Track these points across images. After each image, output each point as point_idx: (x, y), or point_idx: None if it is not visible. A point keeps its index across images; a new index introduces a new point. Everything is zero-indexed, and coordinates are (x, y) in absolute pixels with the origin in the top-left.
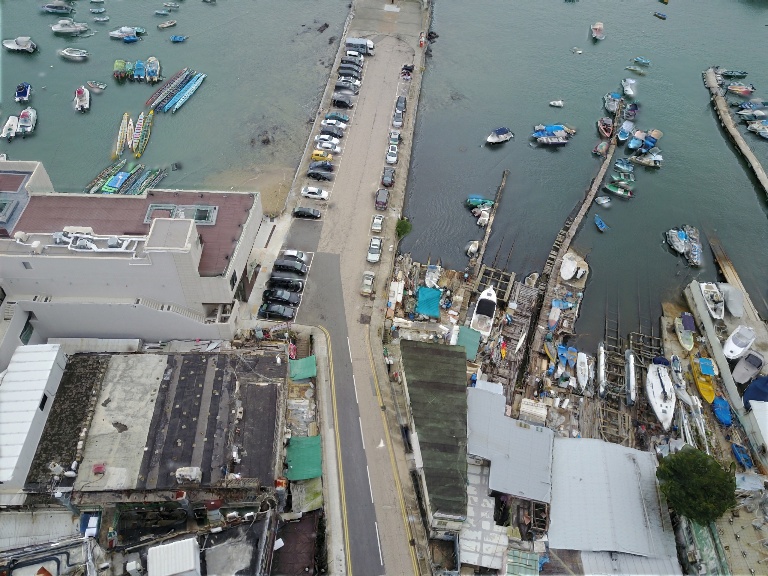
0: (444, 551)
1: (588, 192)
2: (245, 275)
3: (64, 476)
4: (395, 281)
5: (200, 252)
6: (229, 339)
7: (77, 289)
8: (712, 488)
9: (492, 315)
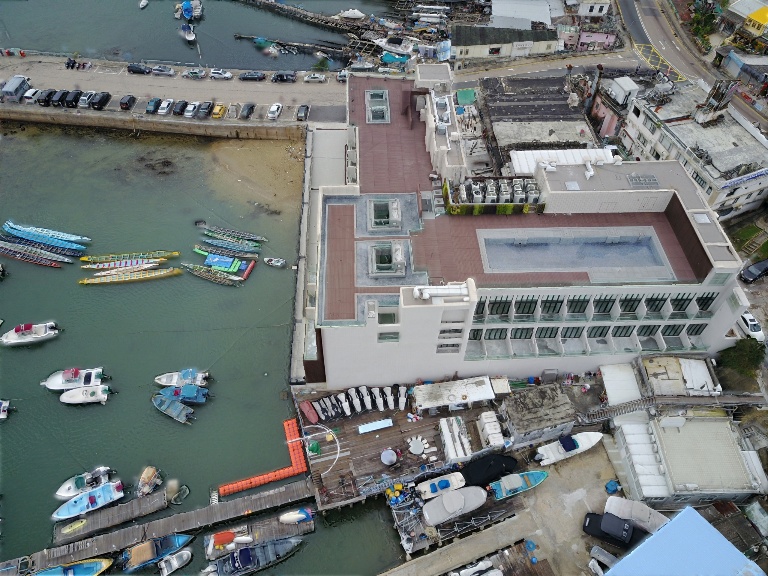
0: None
1: (264, 6)
2: None
3: None
4: None
5: None
6: None
7: None
8: None
9: None
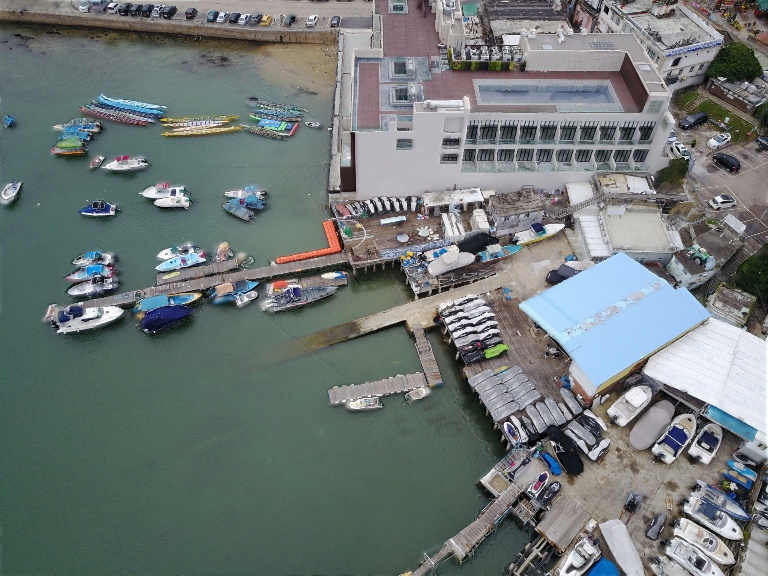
0: None
1: None
2: None
3: None
4: None
5: None
6: None
7: None
8: None
9: None
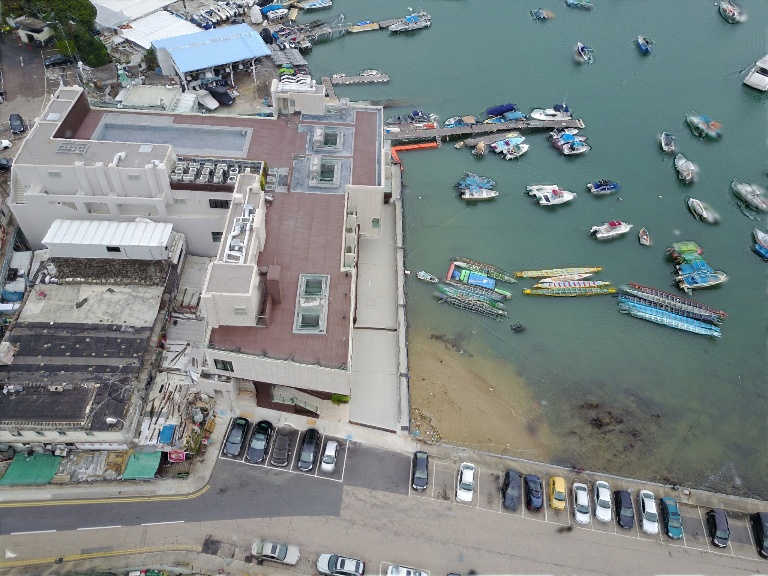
0: None
1: None
2: (262, 387)
3: None
4: None
5: (248, 323)
6: None
7: None
8: None
9: None
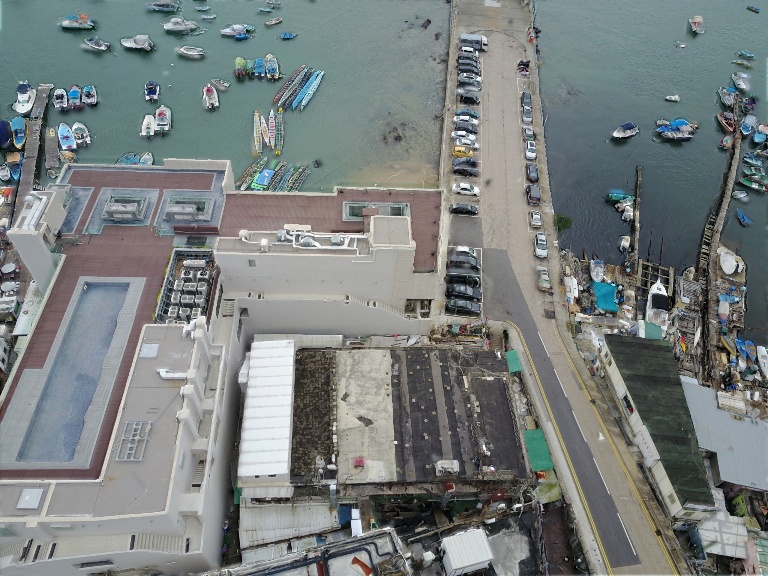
0: (679, 541)
1: (724, 186)
2: None
3: (326, 469)
4: (565, 276)
5: None
6: (426, 334)
7: (291, 286)
8: None
9: (669, 309)
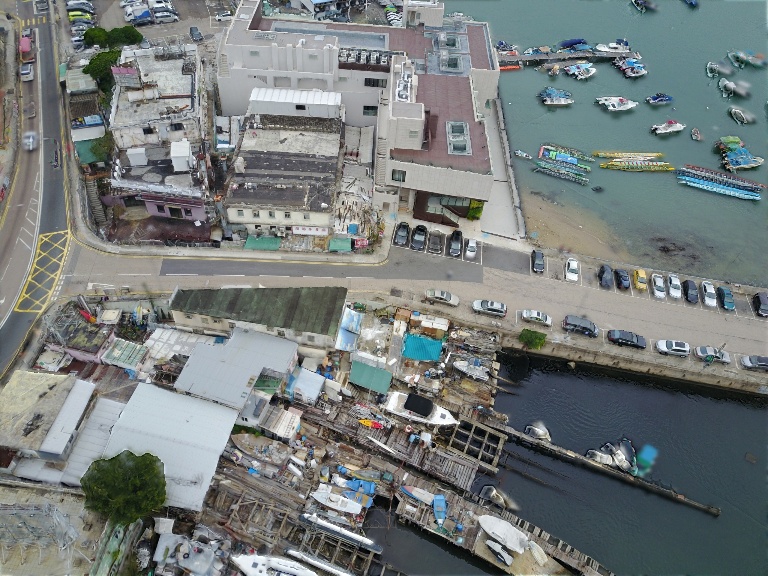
0: None
1: None
2: (423, 197)
3: None
4: (454, 328)
5: (416, 147)
6: None
7: None
8: (103, 472)
9: (408, 407)
